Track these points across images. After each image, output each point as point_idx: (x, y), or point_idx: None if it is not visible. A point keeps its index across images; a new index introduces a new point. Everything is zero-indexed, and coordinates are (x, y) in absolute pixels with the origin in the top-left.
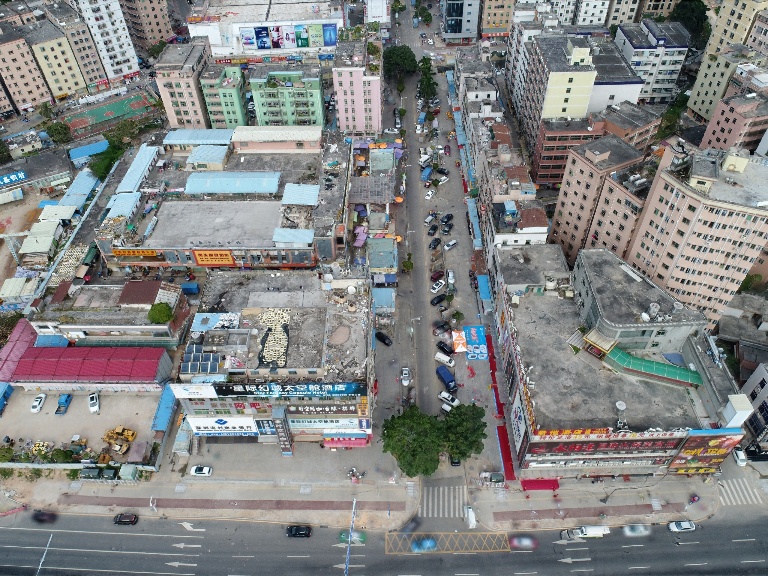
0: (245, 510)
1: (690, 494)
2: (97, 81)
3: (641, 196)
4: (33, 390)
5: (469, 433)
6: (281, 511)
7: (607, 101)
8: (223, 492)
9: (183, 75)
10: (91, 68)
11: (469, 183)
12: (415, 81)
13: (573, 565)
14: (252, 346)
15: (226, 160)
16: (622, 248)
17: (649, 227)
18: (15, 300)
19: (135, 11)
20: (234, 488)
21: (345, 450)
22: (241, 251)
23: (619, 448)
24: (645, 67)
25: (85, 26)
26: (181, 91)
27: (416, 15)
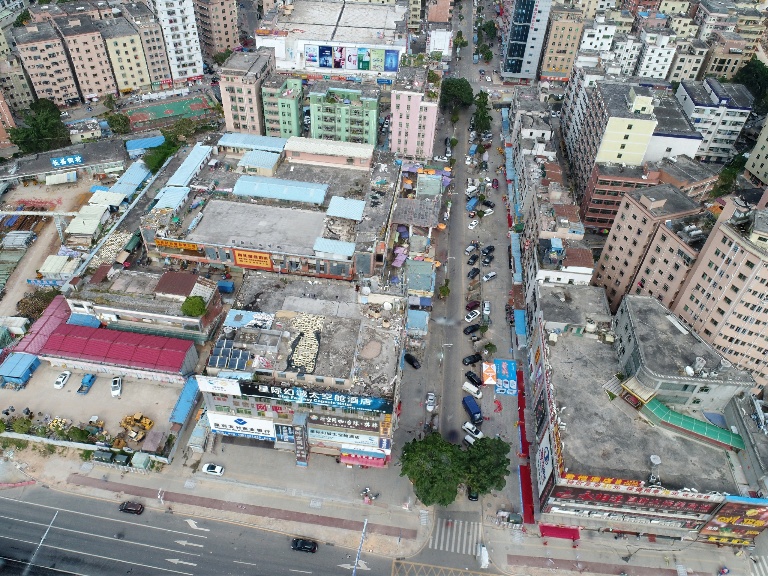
0: (252, 516)
1: (719, 565)
2: (162, 80)
3: (695, 247)
4: (59, 366)
5: (492, 467)
6: (288, 522)
7: (663, 153)
8: (232, 494)
9: (246, 81)
10: (158, 67)
11: (514, 218)
12: (469, 114)
13: None
14: (282, 348)
15: (276, 167)
16: (669, 299)
17: (701, 280)
18: (54, 277)
19: (207, 19)
20: (244, 491)
21: (361, 468)
22: (280, 256)
23: (649, 504)
24: (704, 125)
25: (159, 27)
26: (242, 96)
27: (477, 52)
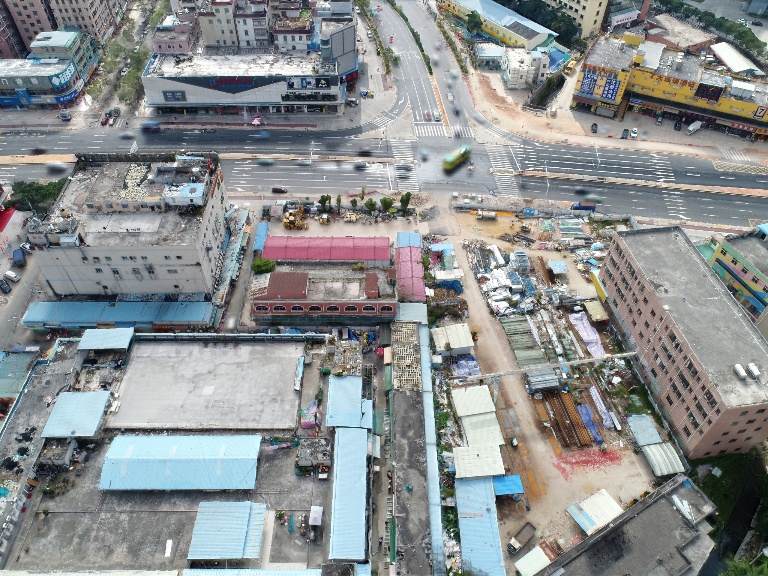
0: None
1: None
2: None
3: None
4: None
5: None
6: None
7: None
8: None
9: None
10: None
11: None
12: None
13: (8, 174)
14: None
15: None
16: None
17: None
18: None
19: None
20: None
21: None
22: None
23: None
24: None
25: None
26: None
27: None
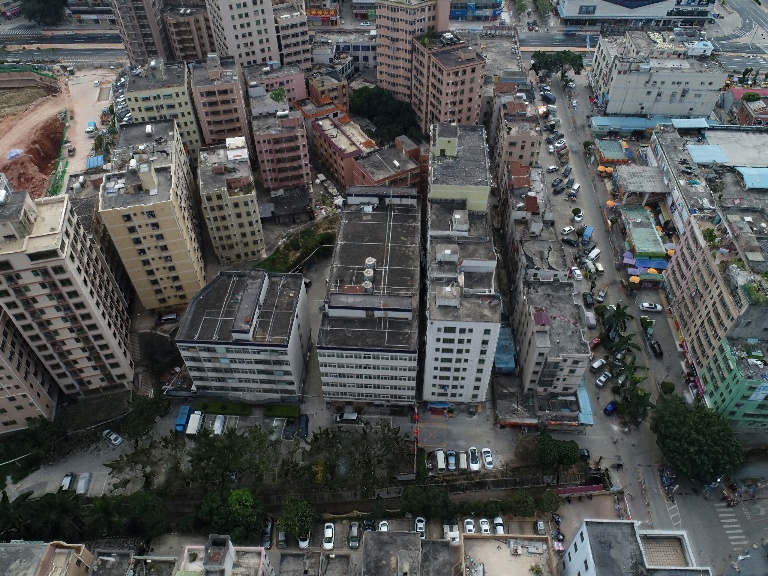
0: None
1: None
2: None
3: None
4: None
5: None
6: None
7: None
8: None
9: None
10: None
11: None
12: (649, 447)
13: None
14: None
15: None
16: None
17: None
18: None
19: None
20: None
21: None
22: None
23: None
24: None
25: None
26: None
27: None
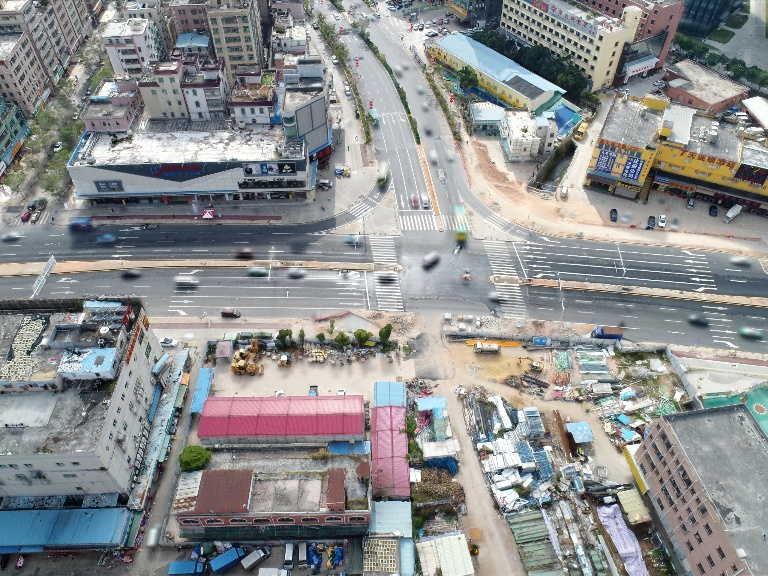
0: None
1: None
2: None
3: None
4: None
5: None
6: None
7: None
8: None
9: None
10: None
11: None
12: None
13: None
14: None
15: None
16: None
17: None
18: None
19: None
20: None
21: None
22: None
23: None
24: None
25: None
26: None
27: None
